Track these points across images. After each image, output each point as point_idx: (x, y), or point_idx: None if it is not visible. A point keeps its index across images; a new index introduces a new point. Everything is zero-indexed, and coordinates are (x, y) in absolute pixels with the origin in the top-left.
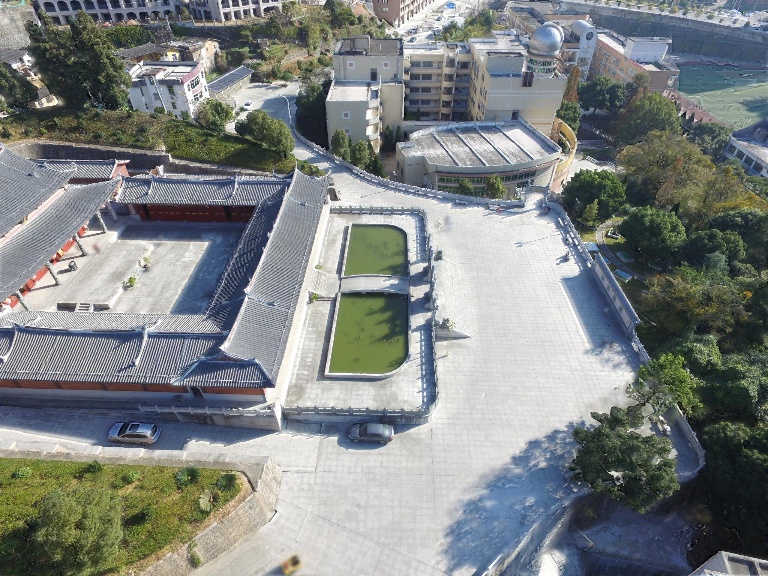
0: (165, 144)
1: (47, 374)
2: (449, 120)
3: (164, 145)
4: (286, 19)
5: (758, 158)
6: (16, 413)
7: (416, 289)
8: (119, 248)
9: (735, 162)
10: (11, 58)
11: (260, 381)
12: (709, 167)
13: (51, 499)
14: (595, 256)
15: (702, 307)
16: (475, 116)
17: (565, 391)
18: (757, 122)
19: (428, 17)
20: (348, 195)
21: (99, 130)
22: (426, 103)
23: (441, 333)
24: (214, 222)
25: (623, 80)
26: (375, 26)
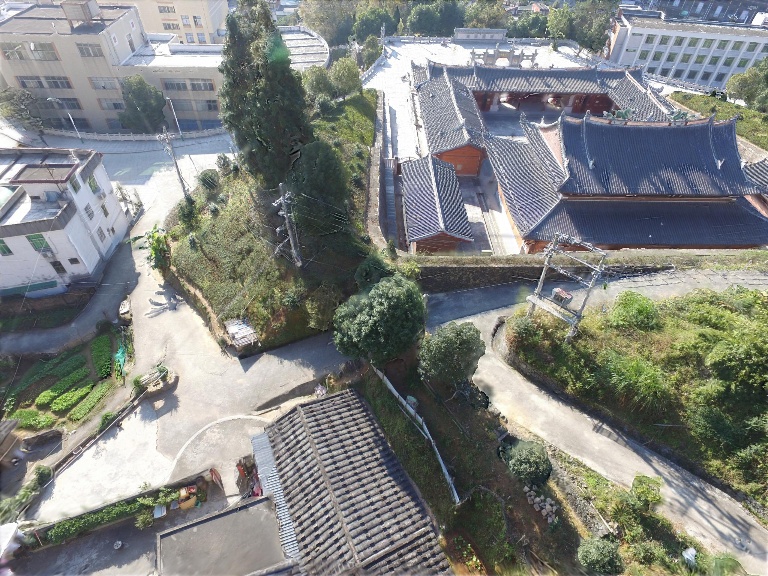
0: None
1: None
2: None
3: None
4: None
5: None
6: None
7: None
8: None
9: None
10: None
11: None
12: None
13: None
14: None
15: None
16: None
17: (548, 57)
18: None
19: None
20: None
21: None
22: None
23: None
24: None
25: None
26: None
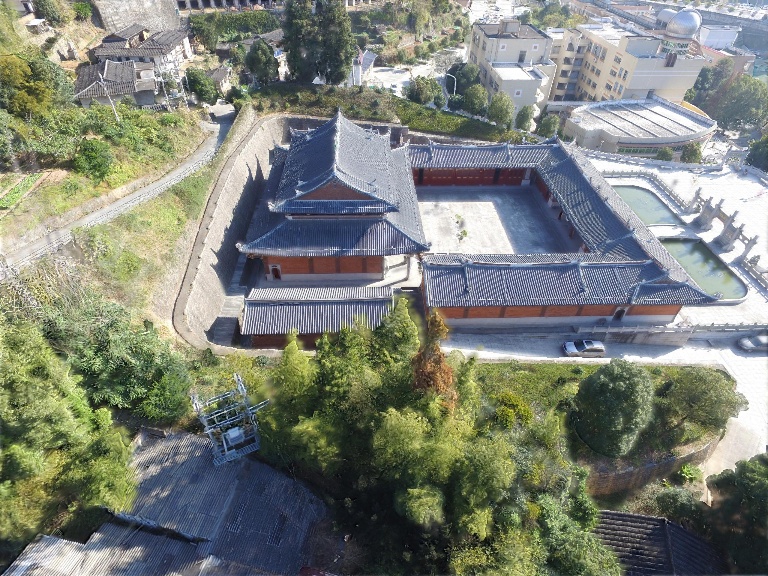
0: (399, 117)
1: (515, 300)
2: None
3: (398, 118)
4: (397, 6)
5: None
6: (474, 339)
7: (700, 235)
8: (422, 208)
9: None
10: (178, 40)
11: (700, 298)
12: None
13: (702, 370)
14: None
15: None
16: (599, 96)
17: None
18: None
19: (485, 7)
20: None
21: (337, 104)
22: None
23: None
24: (481, 186)
25: None
26: (460, 14)
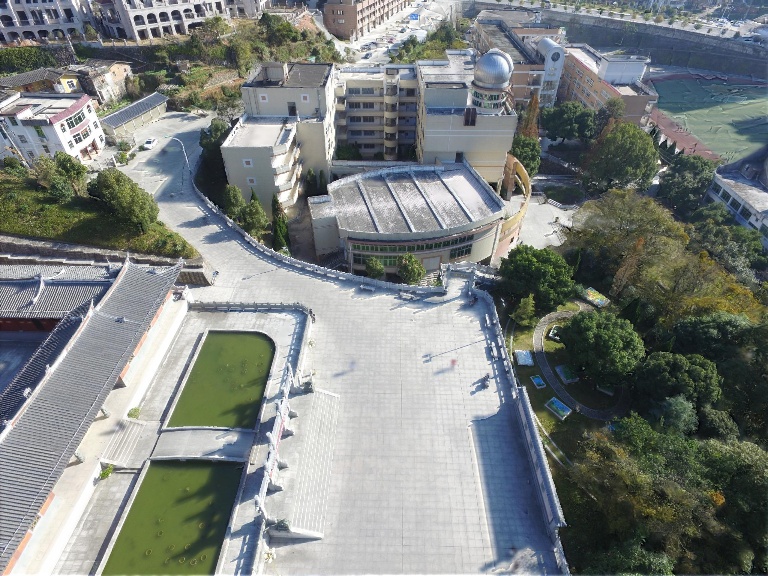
0: None
1: None
2: (395, 154)
3: None
4: (211, 37)
5: (746, 202)
6: None
7: (262, 449)
8: None
9: (719, 206)
10: None
11: None
12: (681, 238)
13: None
14: (518, 390)
15: (653, 507)
16: (419, 153)
17: None
18: (745, 157)
19: (391, 28)
20: (227, 276)
21: None
22: (370, 133)
23: (279, 534)
24: (21, 332)
25: (597, 103)
26: (323, 42)
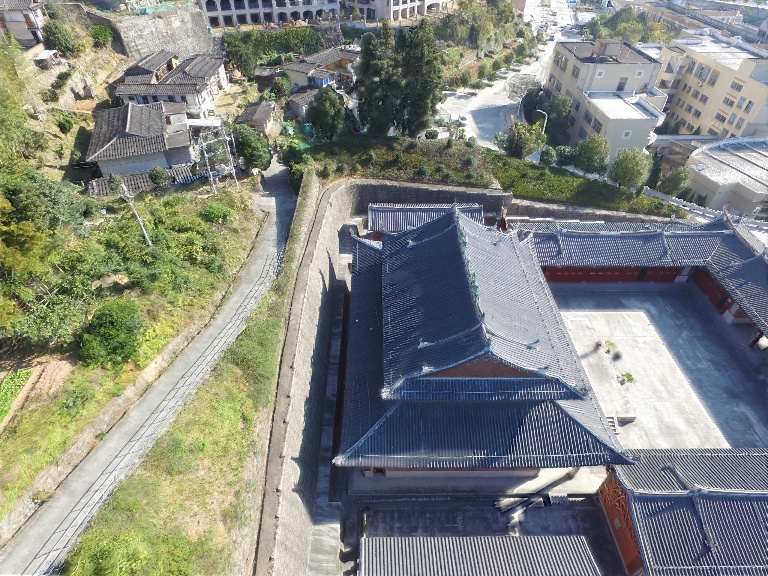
0: (498, 180)
1: None
2: None
3: (498, 181)
4: (458, 18)
5: None
6: None
7: None
8: None
9: None
10: (213, 69)
11: None
12: None
13: None
14: None
15: None
16: (704, 128)
17: None
18: None
19: (540, 12)
20: None
21: (420, 165)
22: None
23: None
24: (620, 282)
25: None
26: (522, 24)
